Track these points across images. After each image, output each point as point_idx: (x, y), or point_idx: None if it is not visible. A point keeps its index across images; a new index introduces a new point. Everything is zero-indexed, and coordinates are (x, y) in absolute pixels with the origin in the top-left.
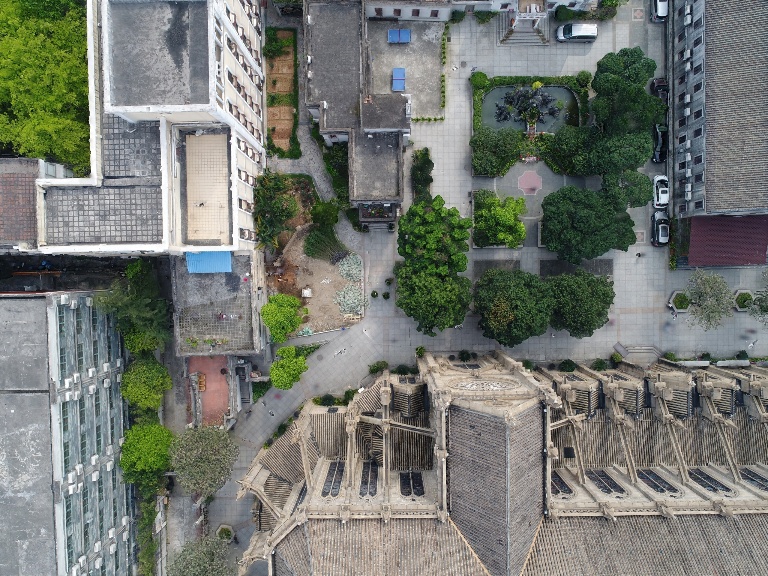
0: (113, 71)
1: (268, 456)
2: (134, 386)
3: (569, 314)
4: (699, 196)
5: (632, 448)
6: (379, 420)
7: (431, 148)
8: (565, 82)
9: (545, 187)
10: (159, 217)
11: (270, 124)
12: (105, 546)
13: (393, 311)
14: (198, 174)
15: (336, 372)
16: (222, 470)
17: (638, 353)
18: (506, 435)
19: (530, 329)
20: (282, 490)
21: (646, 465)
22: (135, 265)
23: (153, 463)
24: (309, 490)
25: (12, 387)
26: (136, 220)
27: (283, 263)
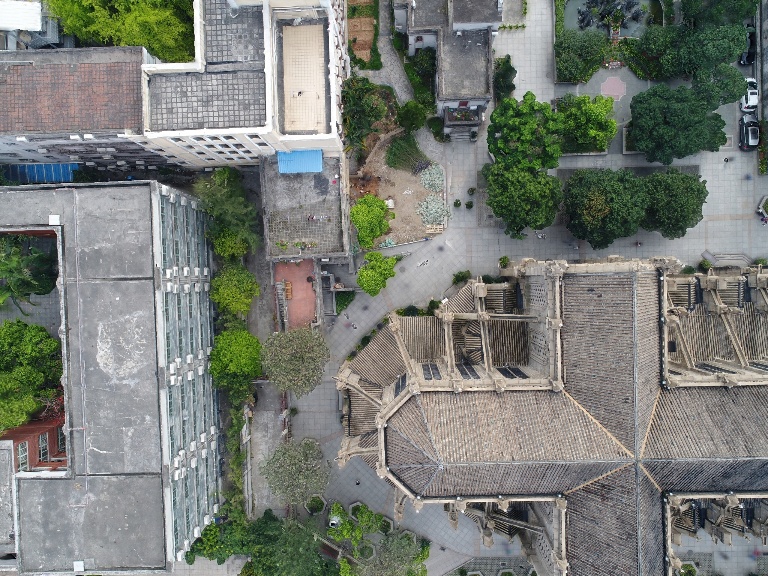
0: None
1: (357, 361)
2: (226, 288)
3: (663, 211)
4: None
5: None
6: (475, 314)
7: (512, 56)
8: None
9: (629, 93)
10: (261, 102)
11: (351, 36)
12: (198, 449)
13: (476, 221)
14: (295, 65)
15: (419, 284)
16: (315, 370)
17: (727, 260)
18: (633, 288)
19: (625, 224)
20: (372, 394)
21: (749, 358)
22: (223, 172)
23: (245, 366)
24: (412, 375)
25: (117, 274)
26: (239, 105)
27: (365, 174)
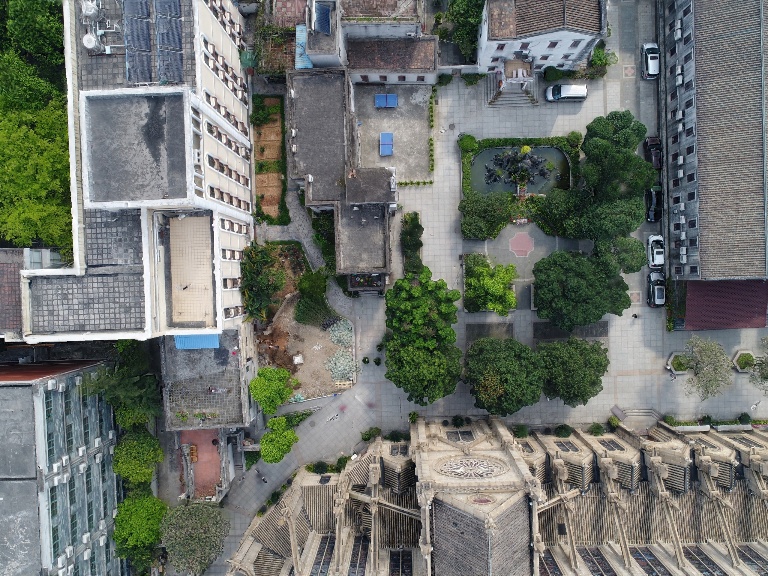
0: (92, 166)
1: (260, 529)
2: (125, 462)
3: (561, 384)
4: (694, 261)
5: (628, 524)
6: (368, 498)
7: (421, 211)
8: (555, 143)
9: (537, 249)
10: (142, 304)
11: (259, 191)
12: None
13: None
14: (182, 256)
15: (329, 438)
16: (213, 547)
17: (636, 416)
18: (487, 539)
19: (521, 402)
20: (274, 564)
21: (643, 542)
22: None
23: (145, 538)
24: None
25: (0, 475)
26: (119, 308)
27: (274, 330)
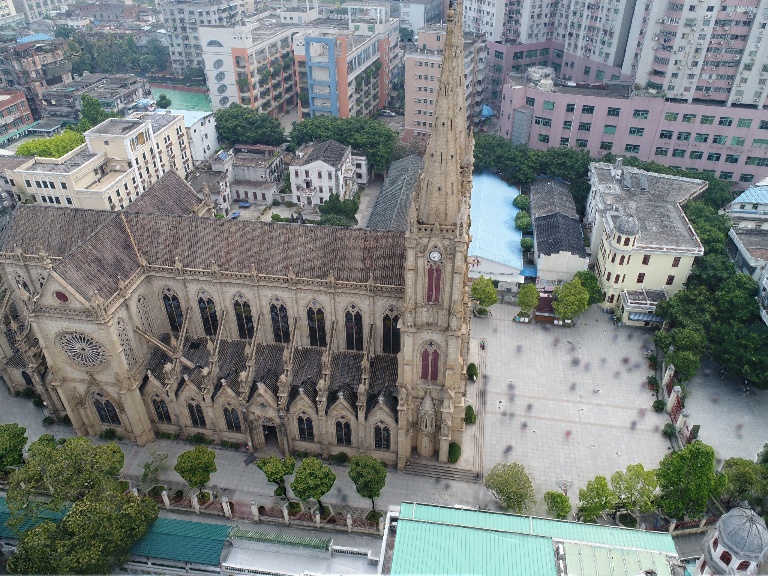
0: None
1: None
2: None
3: None
4: None
5: None
6: None
7: None
8: None
9: None
10: None
11: None
12: None
13: None
14: (106, 179)
15: None
16: None
17: None
18: None
19: None
20: None
21: None
22: None
23: None
24: None
25: None
26: None
27: None
